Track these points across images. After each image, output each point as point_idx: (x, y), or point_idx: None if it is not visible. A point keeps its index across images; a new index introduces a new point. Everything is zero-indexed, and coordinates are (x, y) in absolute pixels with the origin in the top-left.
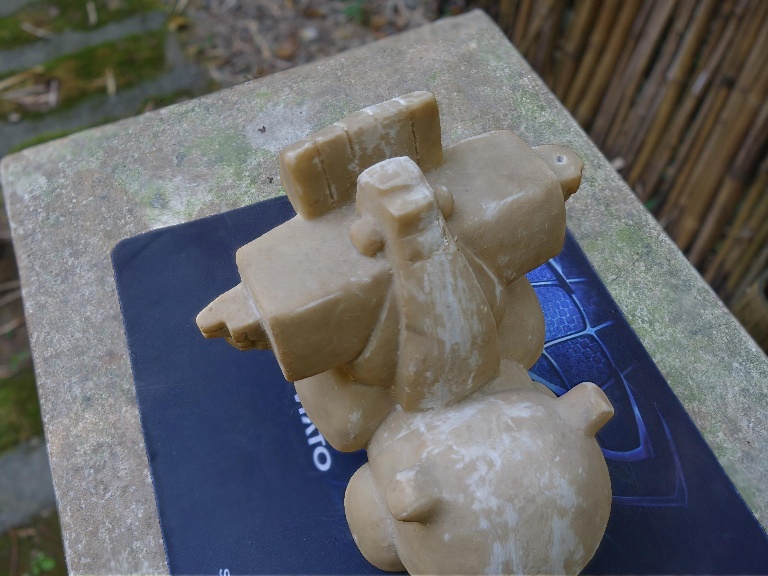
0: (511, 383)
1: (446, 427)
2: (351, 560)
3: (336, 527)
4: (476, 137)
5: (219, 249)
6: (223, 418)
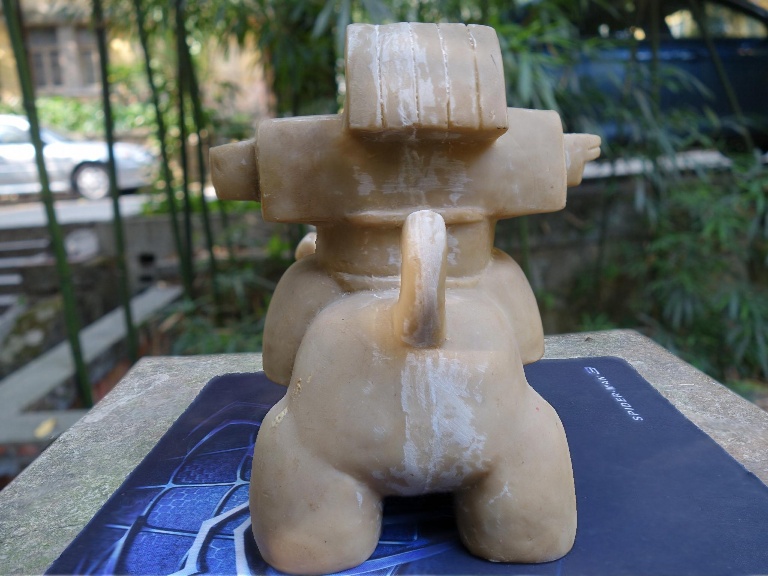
0: None
1: None
2: None
3: None
4: (296, 118)
5: None
6: (660, 489)
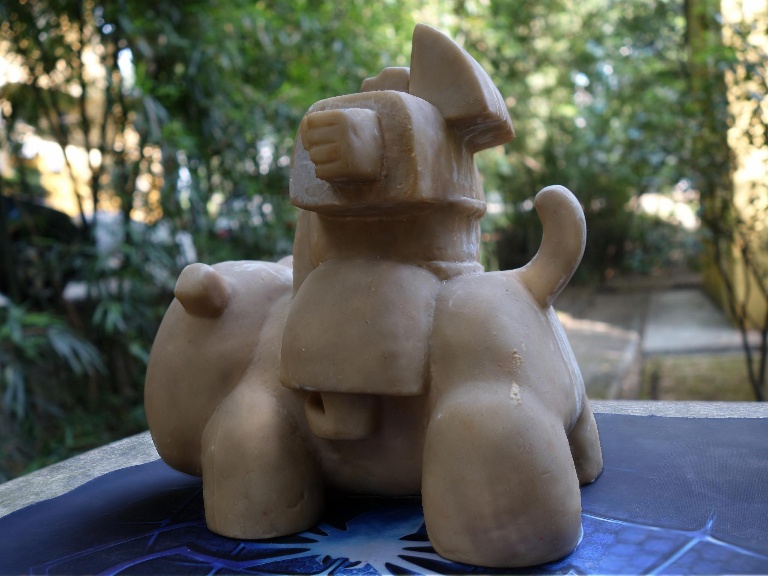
0: (279, 304)
1: None
2: None
3: None
4: None
5: (767, 455)
6: None
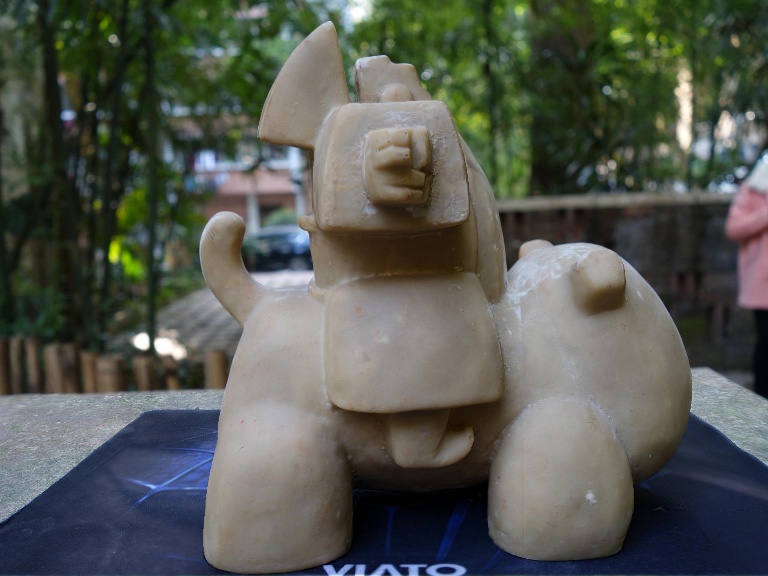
0: None
1: (534, 271)
2: (606, 572)
3: (555, 574)
4: None
5: None
6: None
